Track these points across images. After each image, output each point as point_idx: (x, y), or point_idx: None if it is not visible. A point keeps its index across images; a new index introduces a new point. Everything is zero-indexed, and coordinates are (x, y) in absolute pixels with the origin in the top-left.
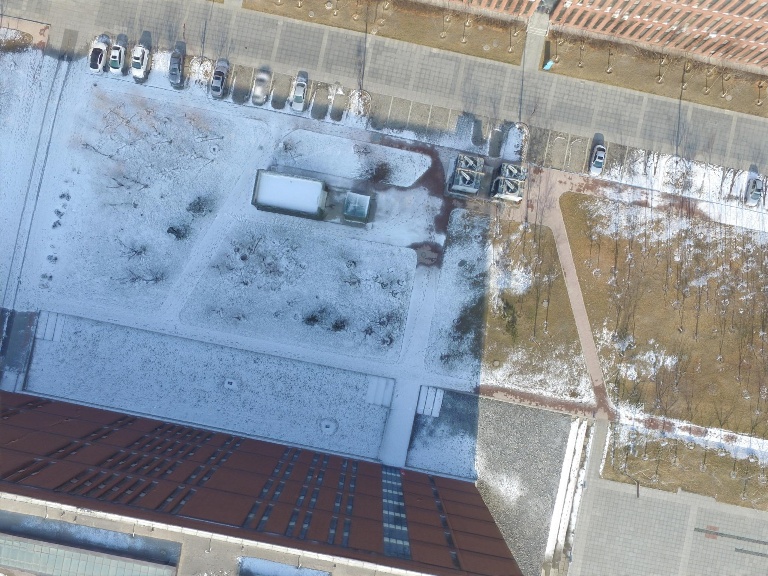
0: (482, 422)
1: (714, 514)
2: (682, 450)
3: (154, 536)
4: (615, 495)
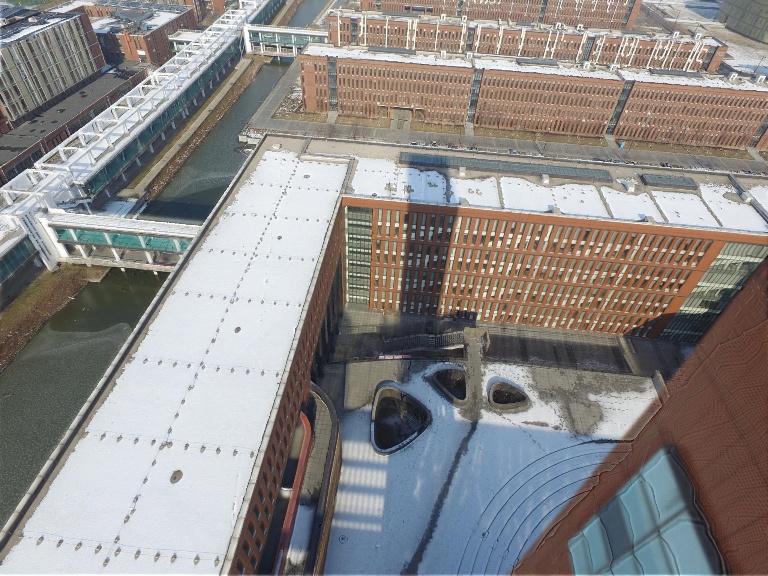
0: None
1: None
2: None
3: (588, 168)
4: None
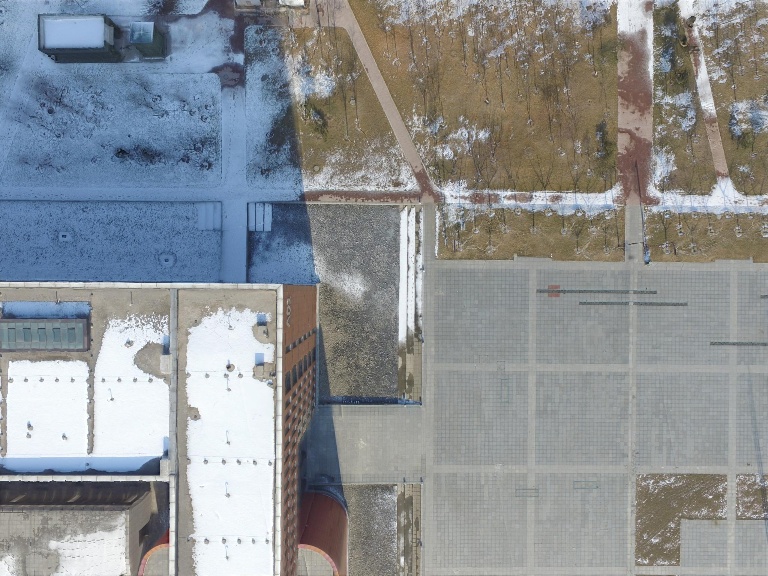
0: (314, 228)
1: (553, 273)
2: (510, 217)
3: None
4: (454, 273)
